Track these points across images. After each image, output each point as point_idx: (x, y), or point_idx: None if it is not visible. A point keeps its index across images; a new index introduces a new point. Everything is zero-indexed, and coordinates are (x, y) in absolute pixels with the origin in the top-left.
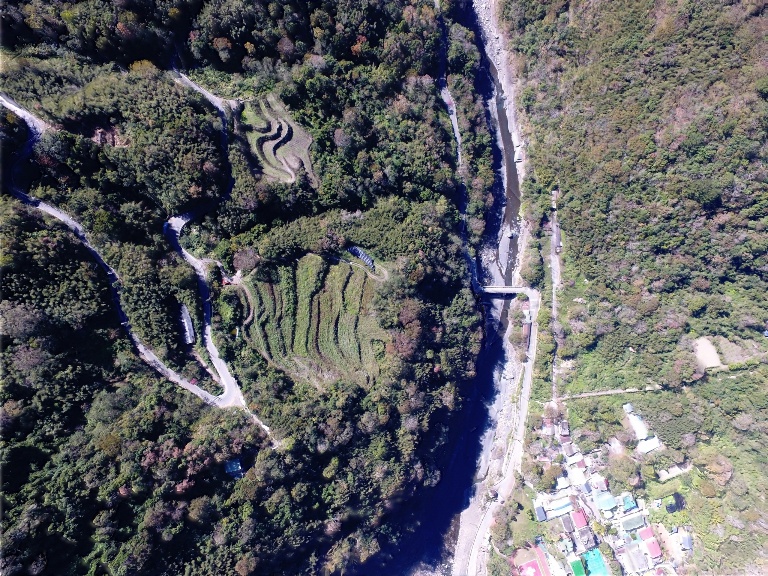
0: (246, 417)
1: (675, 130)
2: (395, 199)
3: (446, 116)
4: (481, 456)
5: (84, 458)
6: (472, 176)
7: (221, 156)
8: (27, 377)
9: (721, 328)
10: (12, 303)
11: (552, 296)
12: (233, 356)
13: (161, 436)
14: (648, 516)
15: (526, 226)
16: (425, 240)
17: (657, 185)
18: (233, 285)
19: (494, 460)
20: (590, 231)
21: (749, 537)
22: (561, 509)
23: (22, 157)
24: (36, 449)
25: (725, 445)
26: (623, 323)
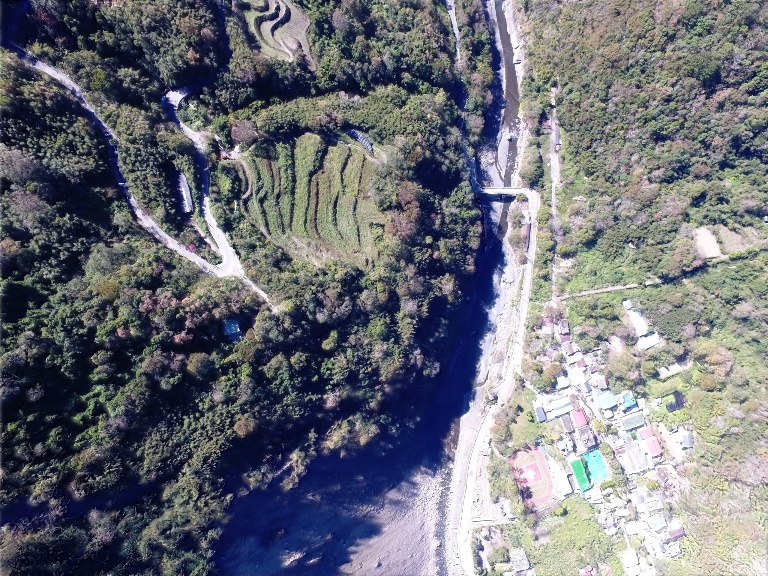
0: (244, 284)
1: (674, 4)
2: (393, 87)
3: (444, 11)
4: (481, 360)
5: (82, 300)
6: (471, 72)
7: (219, 27)
8: (24, 220)
9: (721, 215)
10: (9, 148)
11: (551, 195)
12: (231, 227)
13: (159, 288)
14: (648, 416)
15: (525, 128)
16: (424, 126)
17: (656, 65)
18: (231, 160)
19: (494, 364)
20: (589, 123)
21: (749, 427)
22: (561, 409)
23: (18, 13)
24: (33, 290)
25: (725, 338)
26: (623, 216)
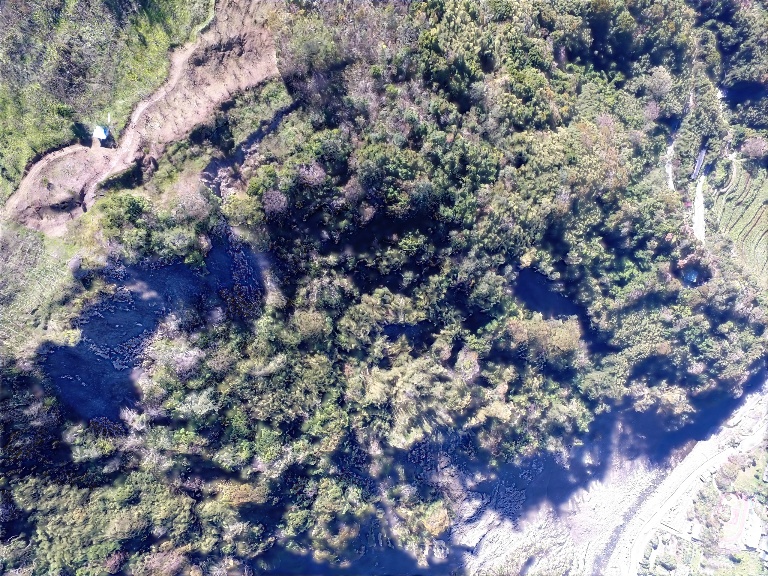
0: None
1: None
2: None
3: None
4: (740, 409)
5: None
6: None
7: None
8: None
9: None
10: None
11: None
12: (709, 207)
13: None
14: None
15: None
16: None
17: None
18: None
19: (749, 418)
20: None
21: None
22: None
23: None
24: None
25: None
26: None
